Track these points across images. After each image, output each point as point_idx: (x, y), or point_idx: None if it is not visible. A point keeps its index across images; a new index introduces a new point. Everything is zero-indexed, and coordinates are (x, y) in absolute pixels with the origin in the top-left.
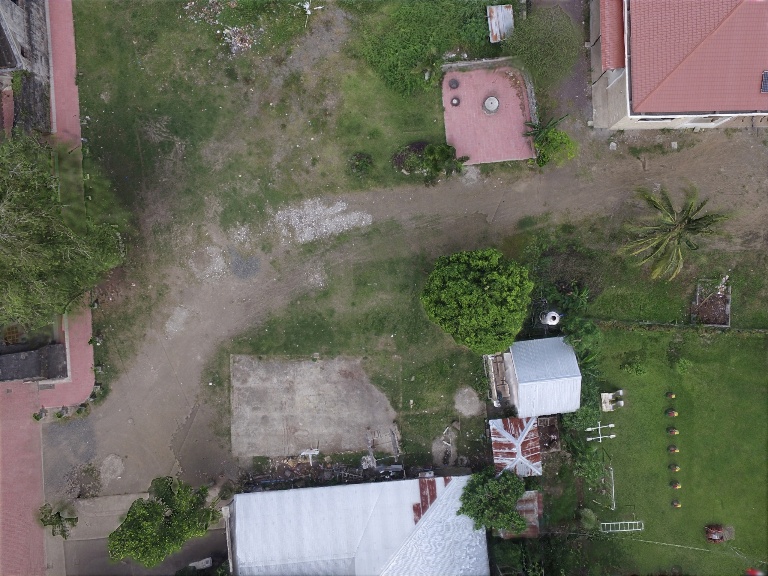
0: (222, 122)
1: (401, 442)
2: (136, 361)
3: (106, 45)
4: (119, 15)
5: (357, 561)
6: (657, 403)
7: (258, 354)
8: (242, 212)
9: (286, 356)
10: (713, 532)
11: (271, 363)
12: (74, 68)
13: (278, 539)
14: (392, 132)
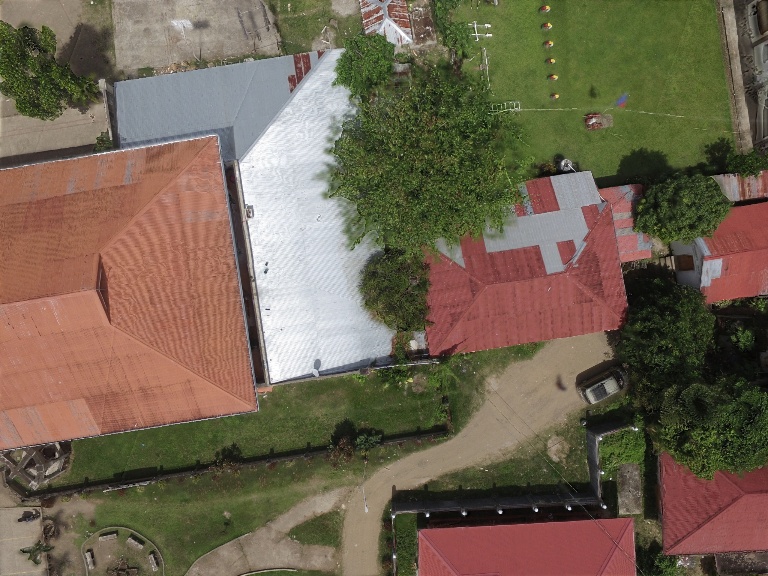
0: None
1: (281, 42)
2: None
3: None
4: None
5: (235, 129)
6: (530, 2)
7: None
8: None
9: None
10: (590, 116)
11: None
12: None
13: (158, 116)
14: None
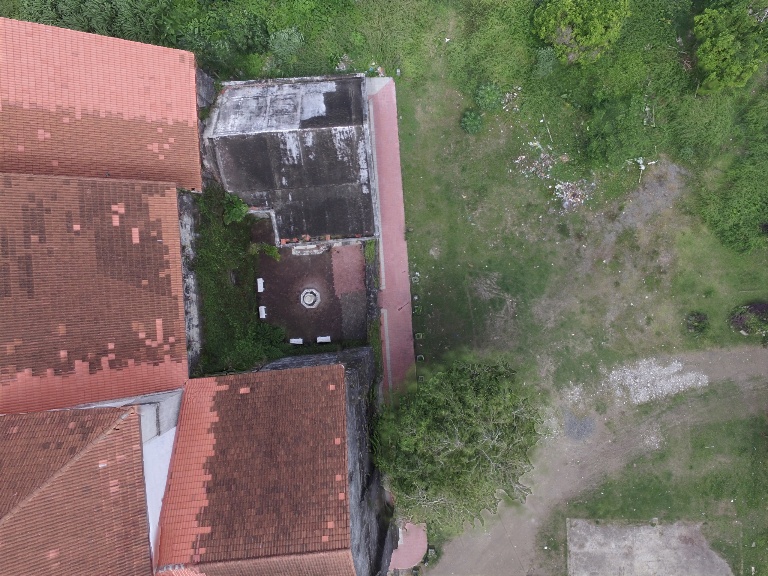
0: (554, 279)
1: None
2: None
3: (435, 199)
4: (448, 168)
5: None
6: None
7: (595, 518)
8: (575, 372)
9: (624, 521)
10: None
11: (609, 528)
12: (403, 223)
13: None
14: (728, 291)
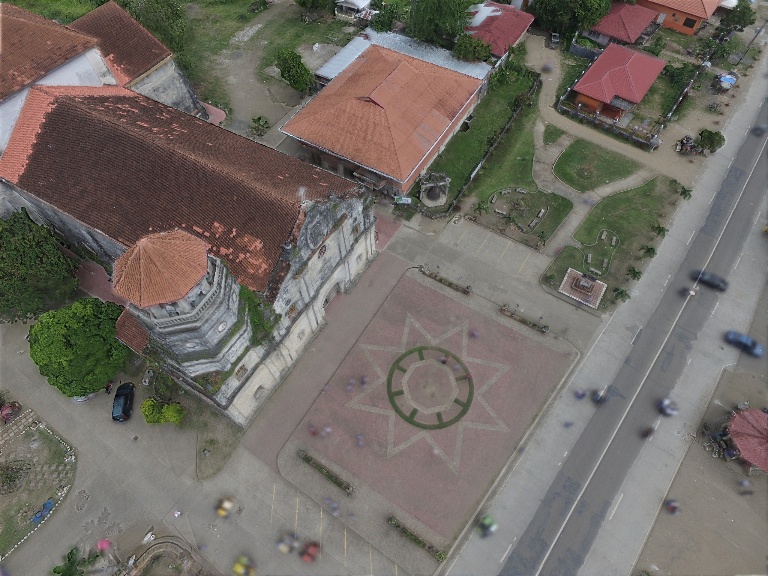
0: None
1: None
2: (230, 96)
3: None
4: None
5: None
6: None
7: (270, 65)
8: None
9: None
10: None
11: None
12: None
13: None
14: (240, 10)
